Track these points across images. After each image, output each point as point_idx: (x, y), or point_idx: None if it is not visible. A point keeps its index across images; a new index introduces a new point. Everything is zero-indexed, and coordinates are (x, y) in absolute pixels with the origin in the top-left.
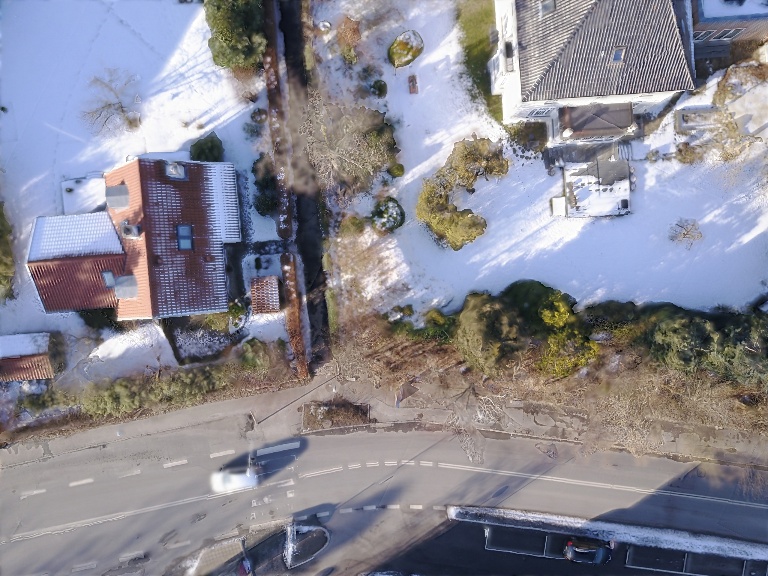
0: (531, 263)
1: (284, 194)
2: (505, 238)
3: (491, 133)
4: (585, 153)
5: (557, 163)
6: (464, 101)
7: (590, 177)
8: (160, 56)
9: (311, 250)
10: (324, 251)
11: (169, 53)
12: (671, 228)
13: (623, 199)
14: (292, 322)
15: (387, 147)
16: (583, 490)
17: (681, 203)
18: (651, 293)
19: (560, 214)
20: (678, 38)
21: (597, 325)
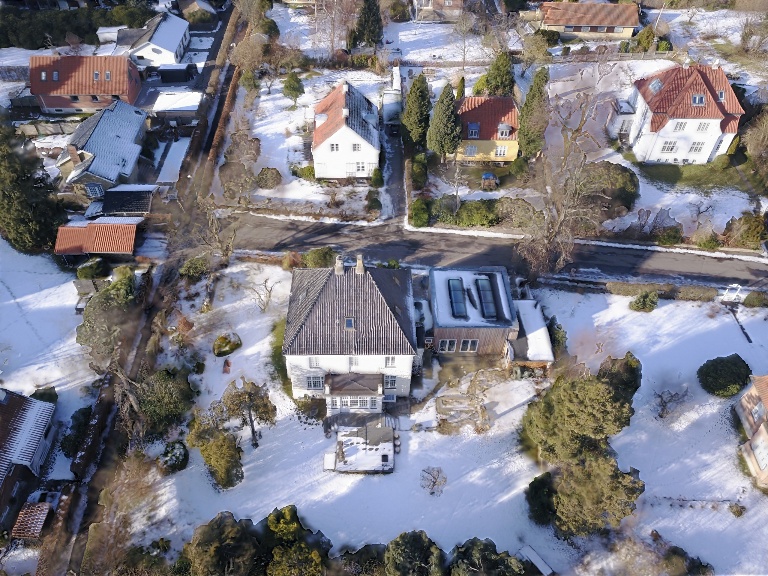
0: (300, 512)
1: (90, 435)
2: (279, 488)
3: (282, 404)
4: (356, 420)
5: (333, 427)
6: (265, 381)
7: (359, 438)
8: (43, 343)
9: (99, 492)
10: (106, 486)
11: (51, 342)
12: (420, 475)
13: None
14: (46, 551)
15: (178, 391)
16: None
17: (440, 465)
18: None
19: (330, 467)
20: (391, 314)
21: (355, 575)
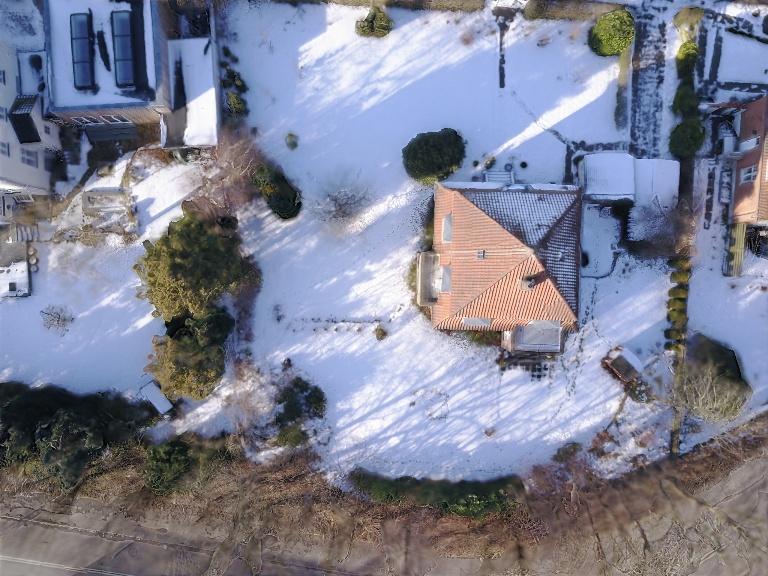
0: None
1: None
2: None
3: None
4: None
5: None
6: None
7: None
8: None
9: None
10: None
11: None
12: (40, 314)
13: (11, 282)
14: None
15: None
16: (13, 566)
17: (80, 286)
18: (52, 375)
19: None
20: None
21: None
